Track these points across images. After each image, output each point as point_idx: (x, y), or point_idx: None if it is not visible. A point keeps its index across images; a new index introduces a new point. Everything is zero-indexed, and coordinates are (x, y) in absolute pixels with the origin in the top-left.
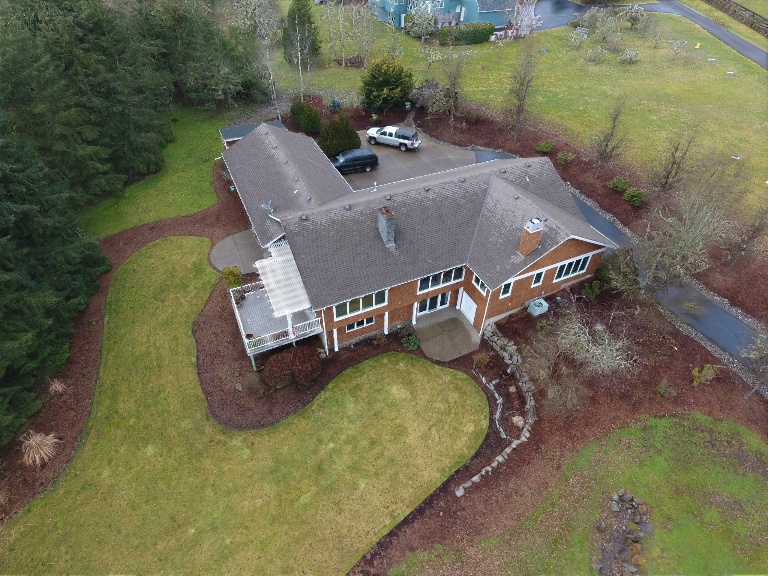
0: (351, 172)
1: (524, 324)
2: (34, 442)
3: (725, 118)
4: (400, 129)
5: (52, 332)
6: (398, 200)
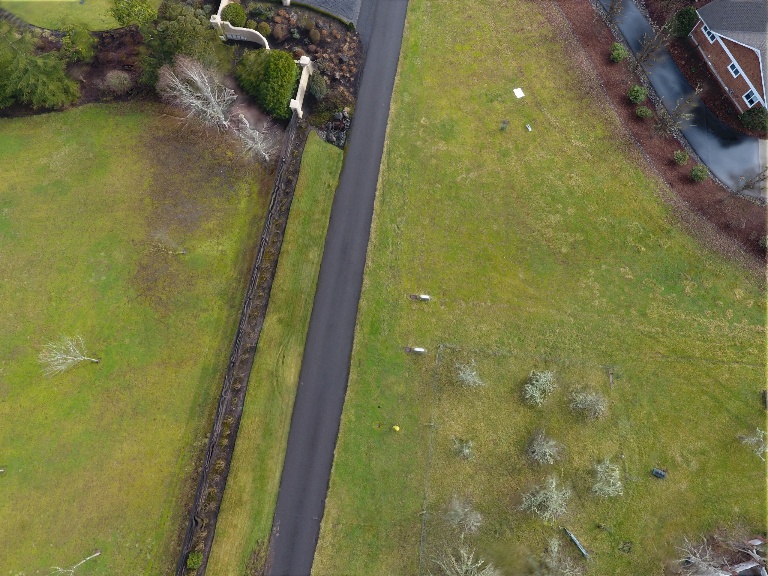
0: None
1: None
2: None
3: (495, 196)
4: None
5: None
6: None
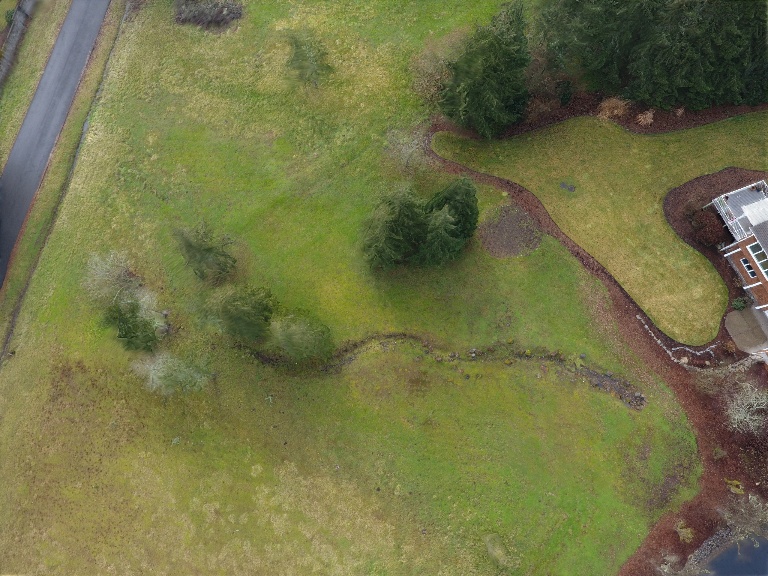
0: None
1: (766, 382)
2: (649, 115)
3: None
4: None
5: (715, 96)
6: None
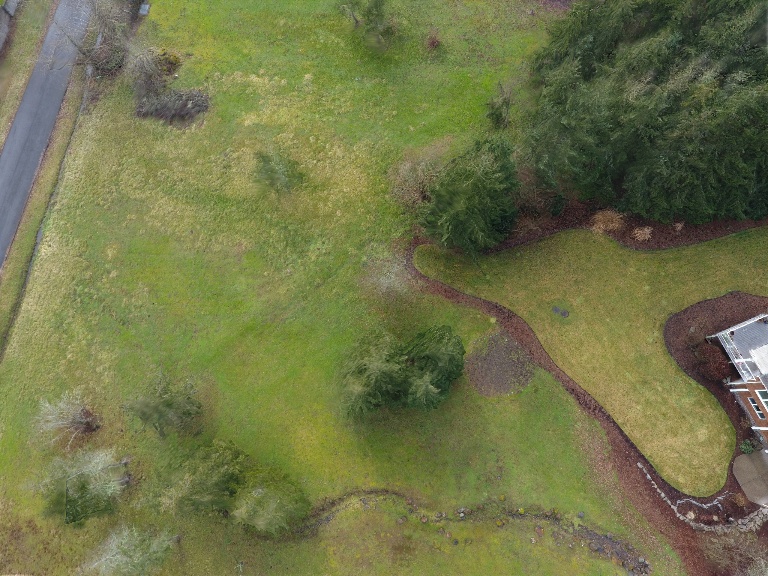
0: None
1: None
2: (646, 232)
3: None
4: None
5: None
6: None
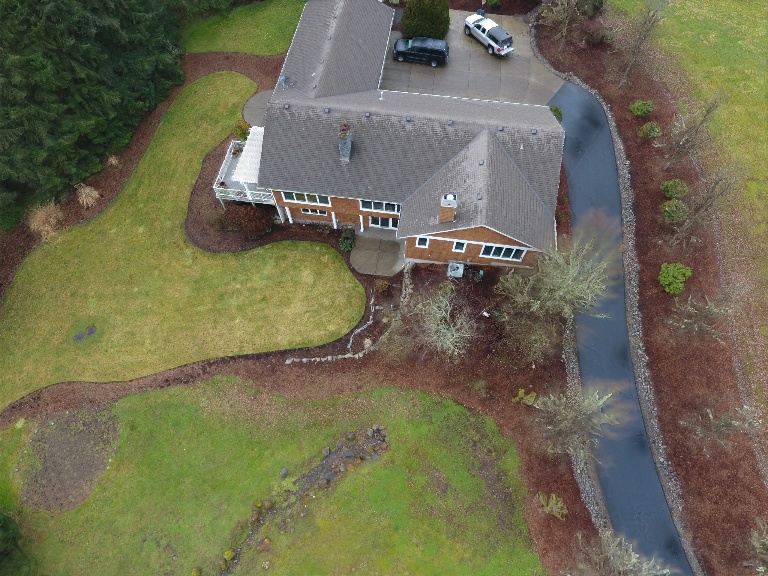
0: (416, 62)
1: (435, 277)
2: (83, 192)
3: None
4: (497, 27)
5: (122, 121)
6: (375, 120)
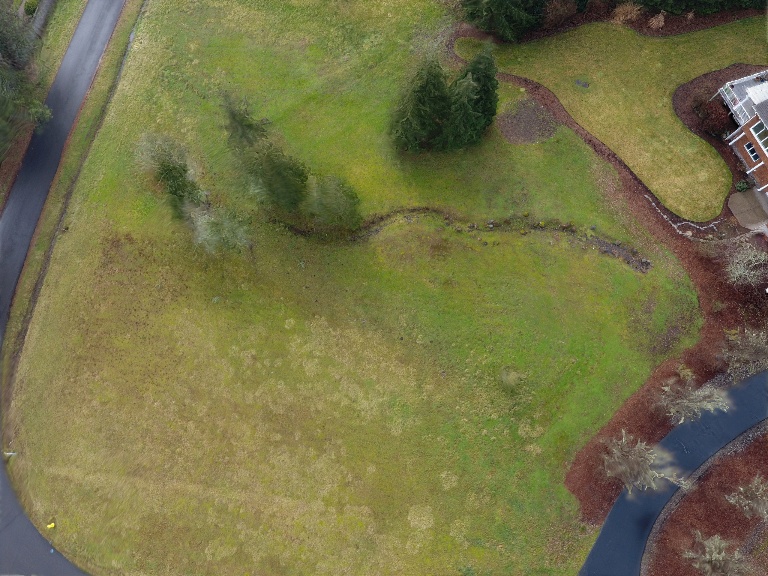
0: None
1: (765, 250)
2: (660, 17)
3: None
4: None
5: None
6: None
